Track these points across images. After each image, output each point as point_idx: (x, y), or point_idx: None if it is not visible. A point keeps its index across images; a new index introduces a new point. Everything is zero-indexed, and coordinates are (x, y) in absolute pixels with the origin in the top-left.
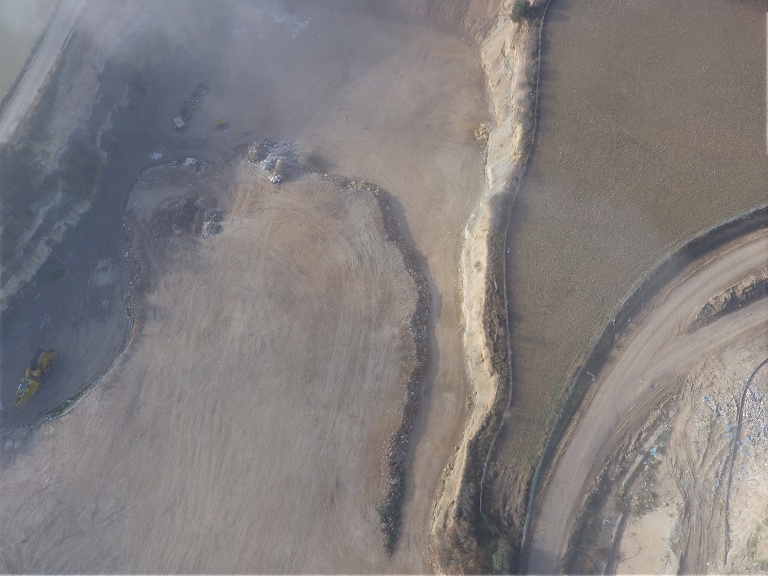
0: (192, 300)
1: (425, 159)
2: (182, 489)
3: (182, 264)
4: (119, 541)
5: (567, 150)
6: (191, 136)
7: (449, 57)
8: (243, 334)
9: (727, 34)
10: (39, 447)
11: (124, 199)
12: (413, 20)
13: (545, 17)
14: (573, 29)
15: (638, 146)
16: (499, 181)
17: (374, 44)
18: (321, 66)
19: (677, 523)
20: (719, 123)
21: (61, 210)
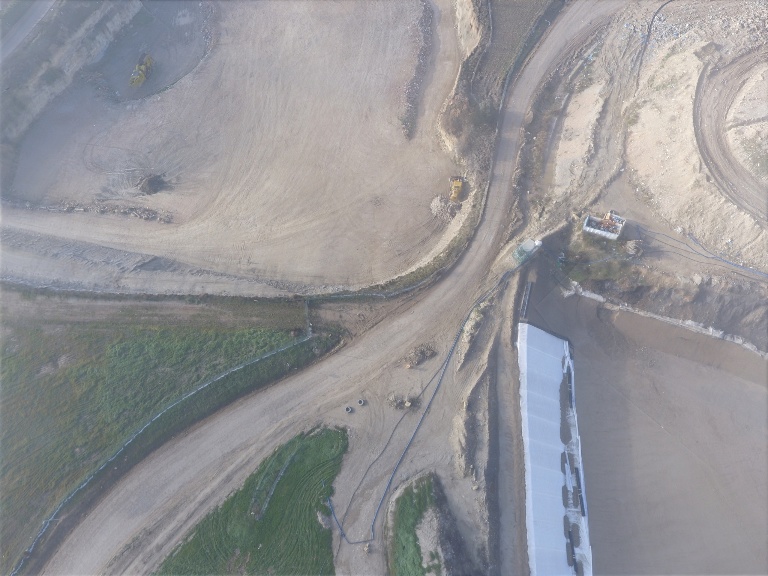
0: (254, 23)
1: None
2: (259, 120)
3: (244, 4)
4: (217, 147)
5: None
6: None
7: None
8: (294, 38)
9: None
10: (152, 107)
11: None
12: None
13: None
14: None
15: None
16: None
17: None
18: None
19: (604, 86)
20: None
21: None
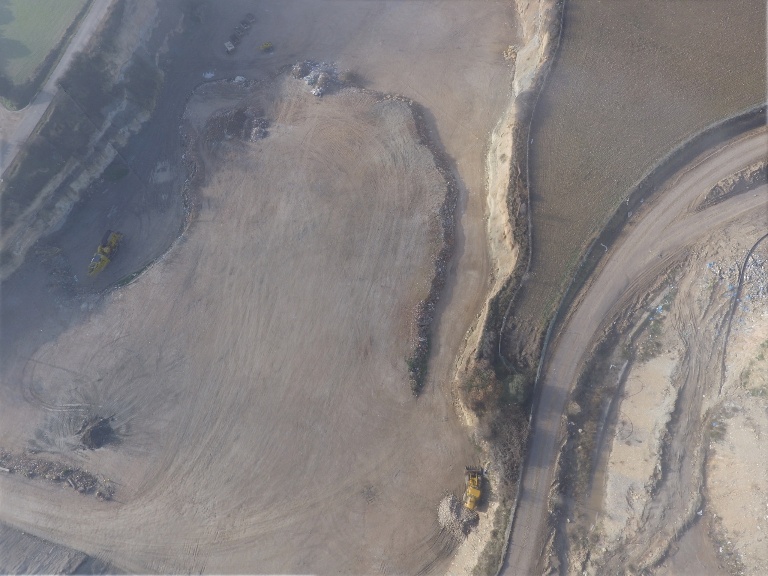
0: (242, 193)
1: (456, 76)
2: (234, 343)
3: (233, 163)
4: (180, 381)
5: (590, 53)
6: (240, 58)
7: None
8: (288, 220)
9: None
10: (110, 308)
11: (180, 111)
12: None
13: None
14: None
15: (657, 49)
16: (525, 89)
17: None
18: None
19: (677, 364)
20: (736, 27)
21: (126, 116)
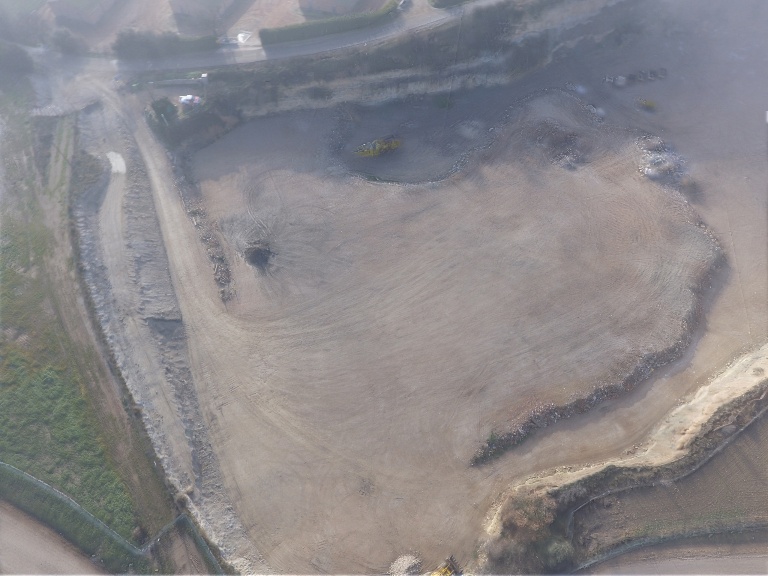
0: (505, 192)
1: None
2: (391, 288)
3: (521, 165)
4: (333, 276)
5: None
6: (608, 93)
7: None
8: (516, 243)
9: None
10: (342, 186)
11: (523, 95)
12: None
13: None
14: None
15: None
16: None
17: None
18: (767, 126)
19: None
20: None
21: (482, 68)
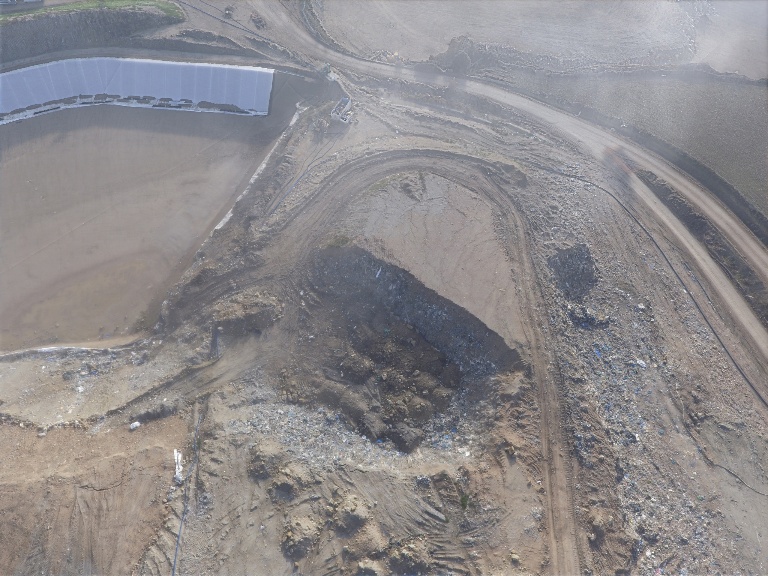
0: None
1: None
2: None
3: None
4: None
5: None
6: None
7: None
8: None
9: None
10: None
11: None
12: None
13: None
14: None
15: None
16: None
17: None
18: None
19: (493, 134)
20: None
21: None
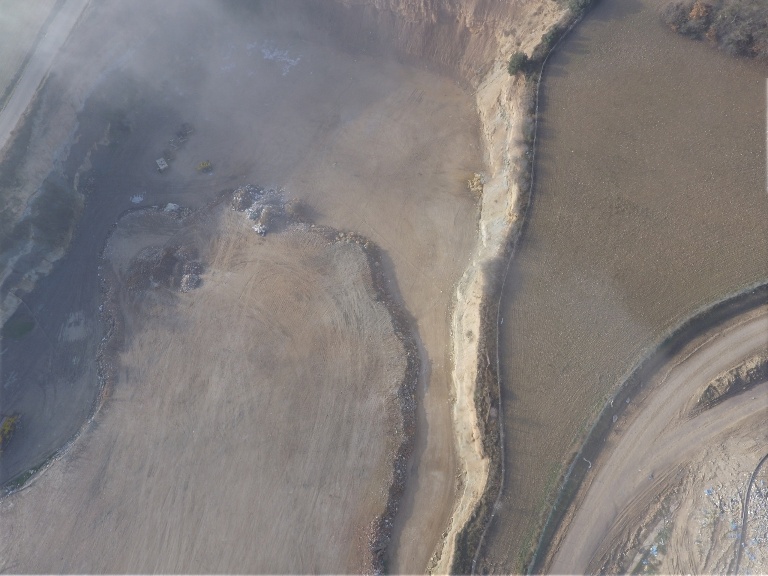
0: (168, 361)
1: (417, 210)
2: None
3: (159, 321)
4: None
5: (564, 214)
6: (174, 179)
7: (444, 101)
8: (220, 401)
9: (730, 96)
10: None
11: (101, 246)
12: (407, 61)
13: (543, 72)
14: (572, 85)
15: (638, 212)
16: (493, 240)
17: (367, 85)
18: (312, 107)
19: None
20: (722, 190)
21: (32, 259)
